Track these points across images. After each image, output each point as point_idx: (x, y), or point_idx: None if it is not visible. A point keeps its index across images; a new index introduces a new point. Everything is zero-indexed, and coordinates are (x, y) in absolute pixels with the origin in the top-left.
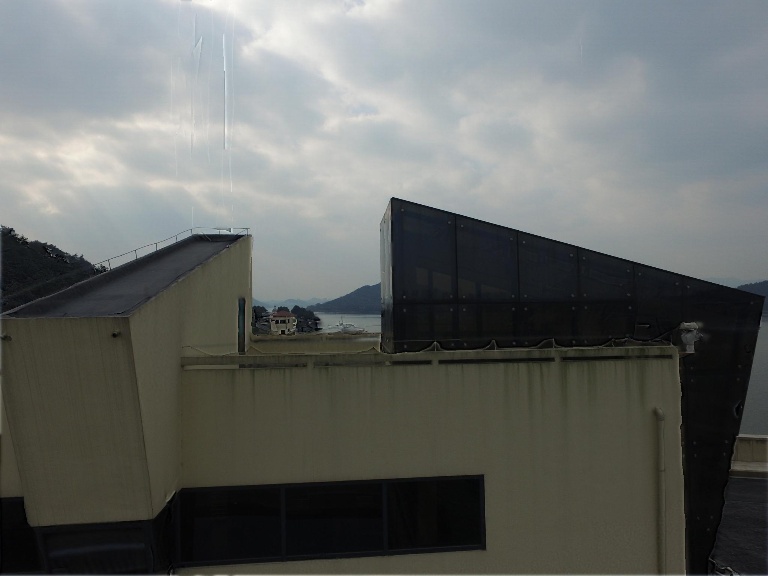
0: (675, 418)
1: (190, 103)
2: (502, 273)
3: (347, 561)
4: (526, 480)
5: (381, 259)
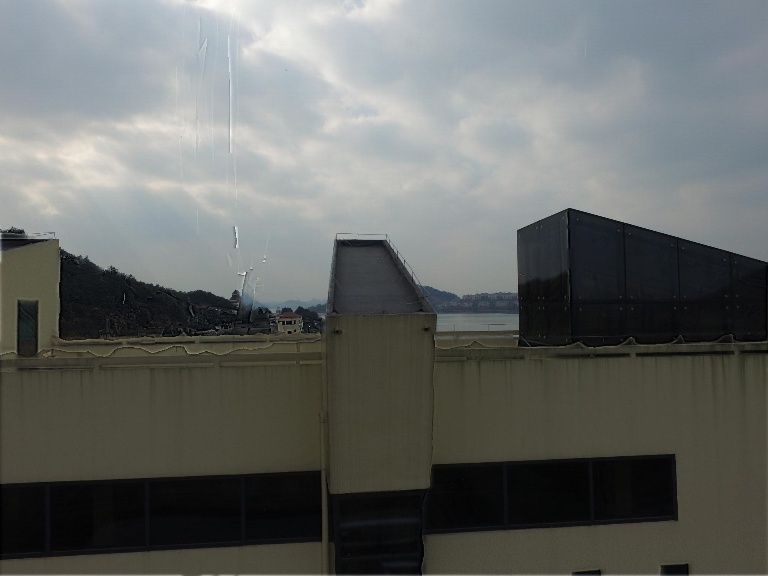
0: None
1: (195, 105)
2: (659, 276)
3: (560, 530)
4: (711, 459)
5: (518, 263)
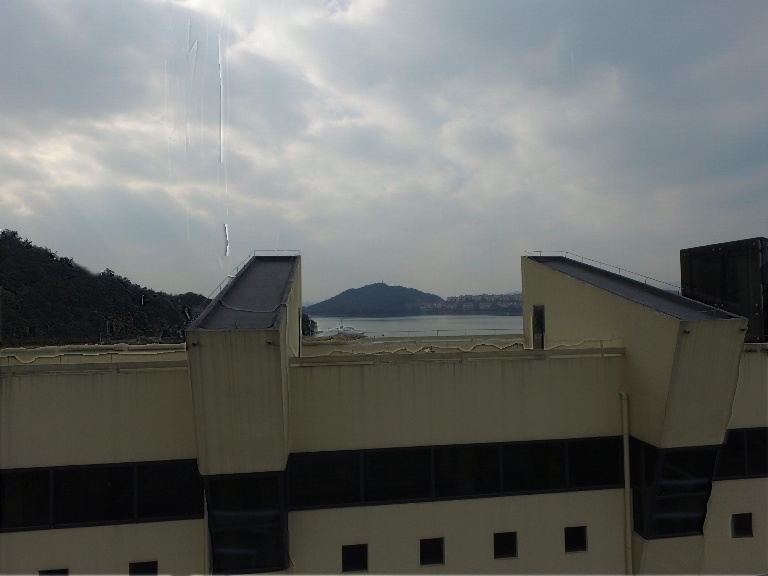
0: None
1: (184, 106)
2: None
3: None
4: None
5: (682, 276)
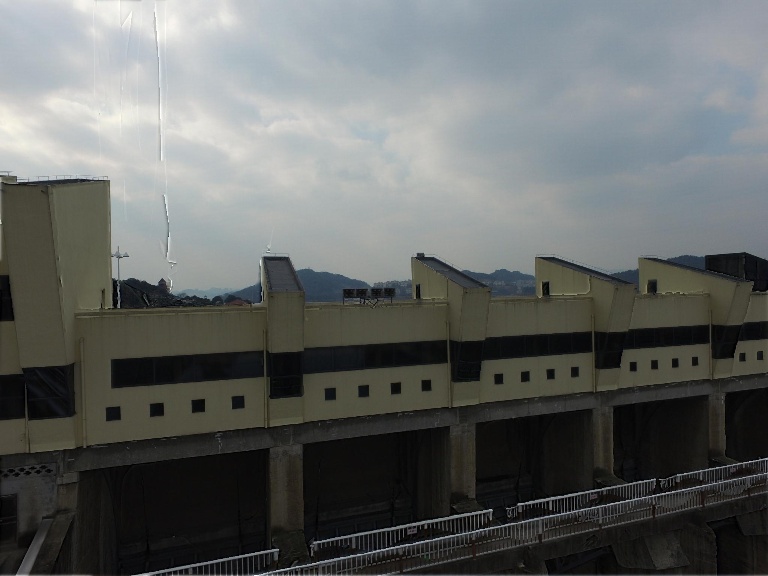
0: None
1: (115, 80)
2: (761, 272)
3: (755, 341)
4: None
5: (705, 267)
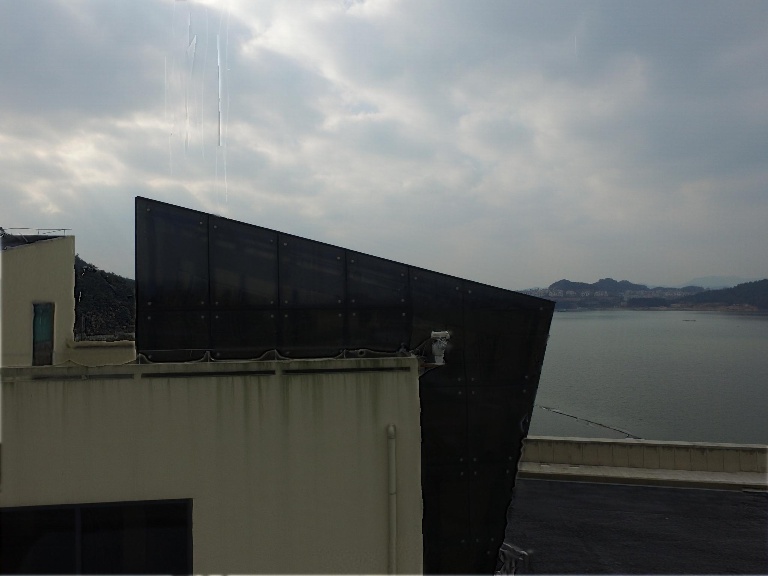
0: (413, 436)
1: None
2: (270, 277)
3: None
4: (241, 504)
5: None
